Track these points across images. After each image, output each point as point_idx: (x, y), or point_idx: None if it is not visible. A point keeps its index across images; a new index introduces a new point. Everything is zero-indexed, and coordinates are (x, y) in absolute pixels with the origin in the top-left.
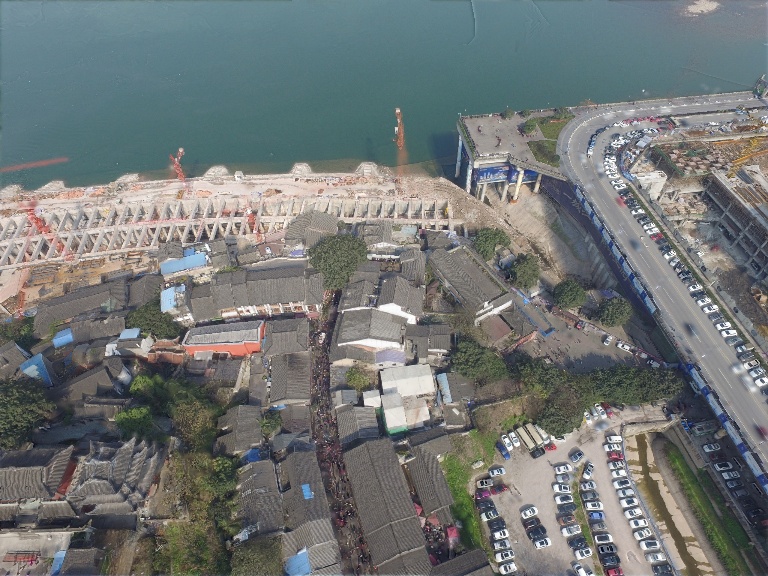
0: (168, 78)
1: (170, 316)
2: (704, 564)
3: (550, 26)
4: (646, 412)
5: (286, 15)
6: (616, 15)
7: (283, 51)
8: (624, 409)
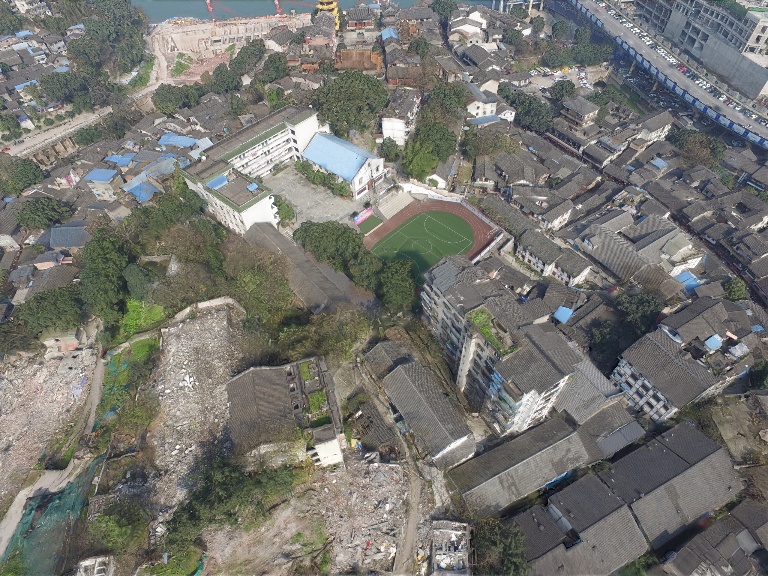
0: None
1: None
2: None
3: None
4: (597, 69)
5: None
6: None
7: None
8: (587, 68)
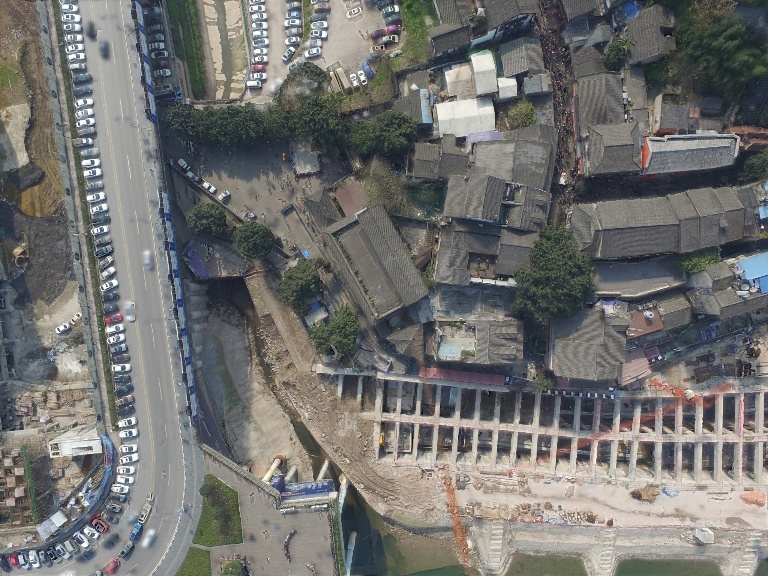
0: None
1: (766, 177)
2: (208, 4)
3: None
4: None
5: None
6: None
7: None
8: None
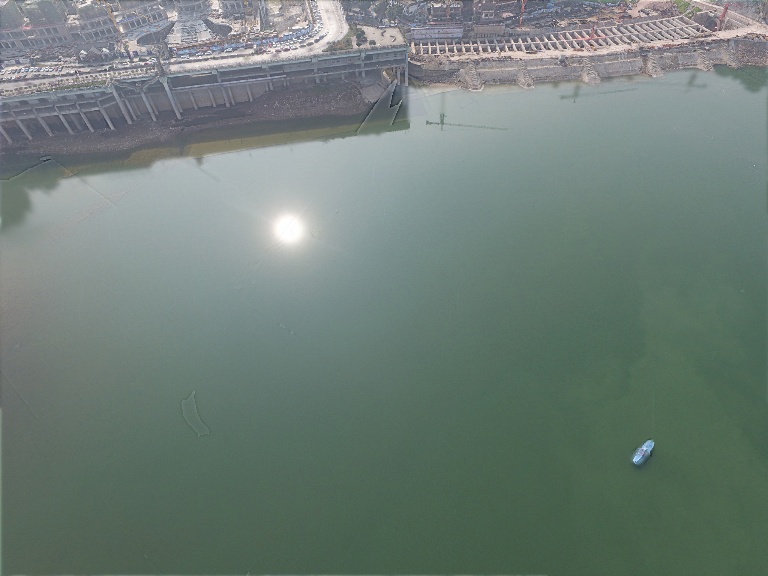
0: (766, 165)
1: None
2: None
3: (212, 336)
4: None
5: (761, 348)
6: (75, 346)
7: (661, 222)
8: None
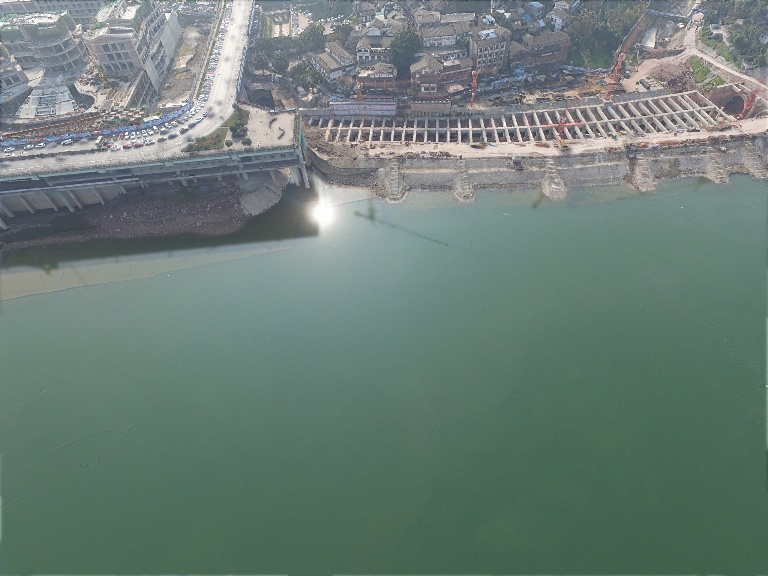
0: None
1: None
2: None
3: None
4: None
5: None
6: None
7: (601, 498)
8: None
